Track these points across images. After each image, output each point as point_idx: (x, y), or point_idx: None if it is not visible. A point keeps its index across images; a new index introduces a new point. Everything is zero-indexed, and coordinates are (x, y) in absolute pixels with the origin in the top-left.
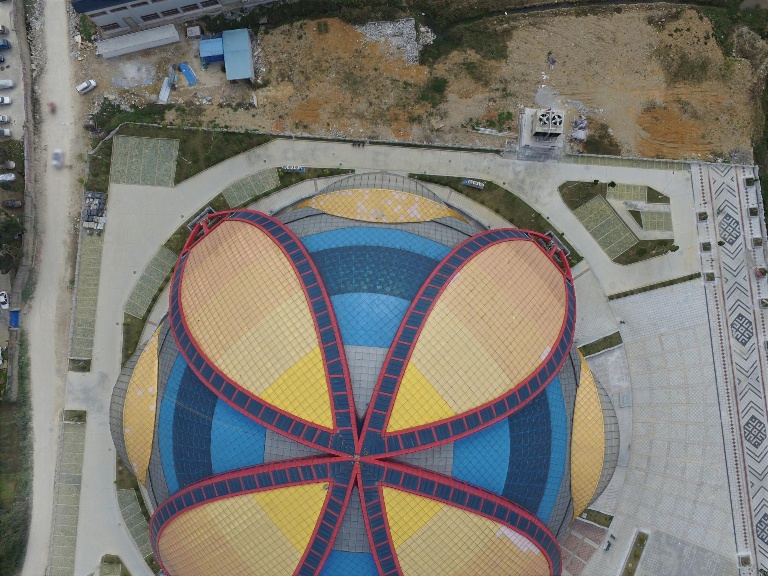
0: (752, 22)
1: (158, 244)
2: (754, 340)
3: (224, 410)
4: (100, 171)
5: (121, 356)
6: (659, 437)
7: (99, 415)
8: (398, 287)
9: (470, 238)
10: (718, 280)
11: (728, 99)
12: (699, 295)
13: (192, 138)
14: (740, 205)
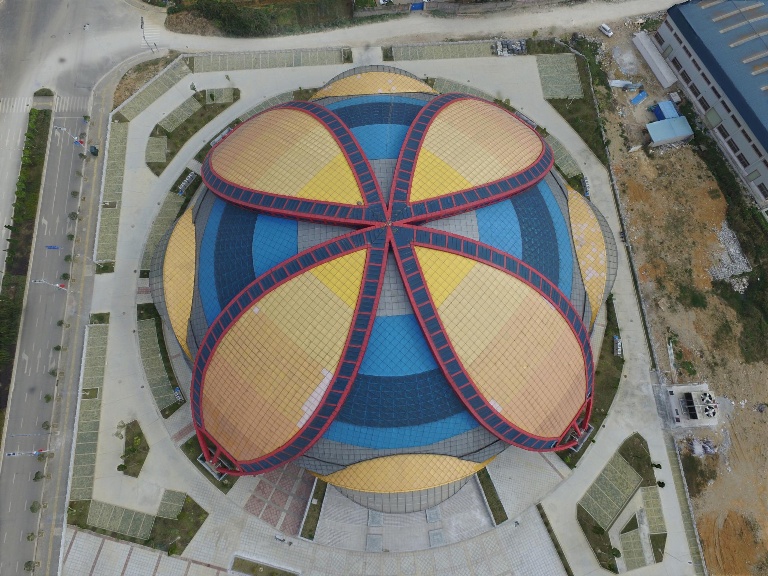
0: None
1: (495, 94)
2: None
3: (399, 130)
4: (543, 48)
5: None
6: None
7: None
8: (530, 255)
9: None
10: None
11: None
12: None
13: (588, 107)
14: None
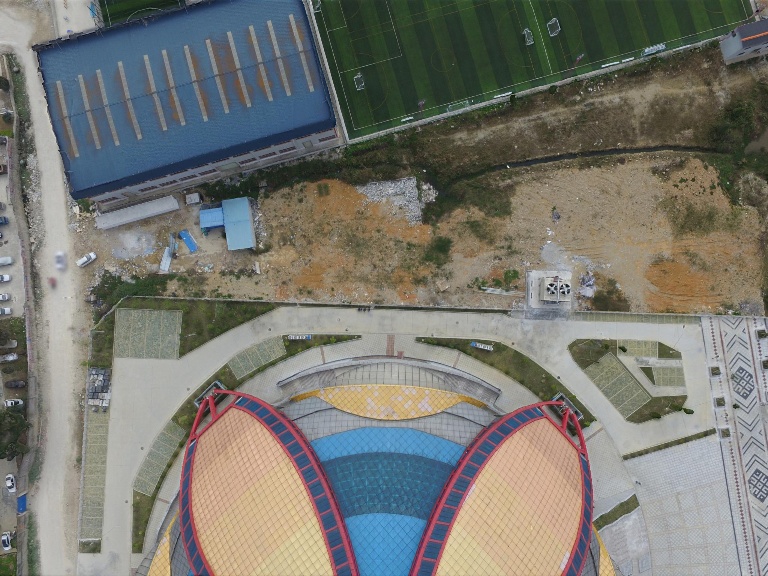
0: (757, 167)
1: (165, 418)
2: None
3: None
4: (103, 346)
5: (131, 535)
6: None
7: None
8: (413, 504)
9: (483, 436)
10: (733, 435)
11: (736, 249)
12: (715, 451)
13: (195, 308)
14: (753, 357)
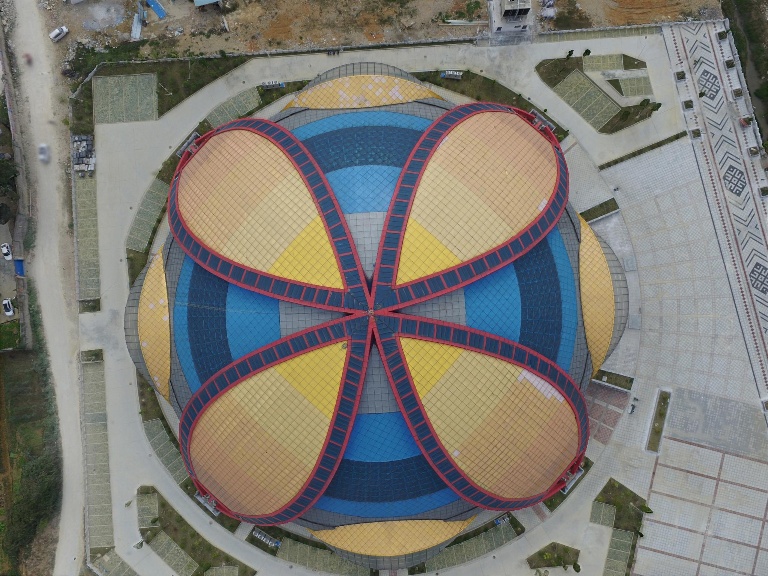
0: None
1: (150, 177)
2: (748, 189)
3: (235, 298)
4: (83, 114)
5: (129, 291)
6: (668, 297)
7: (115, 352)
8: (389, 157)
9: (454, 108)
10: (704, 136)
11: None
12: (688, 153)
13: (169, 69)
14: (716, 60)
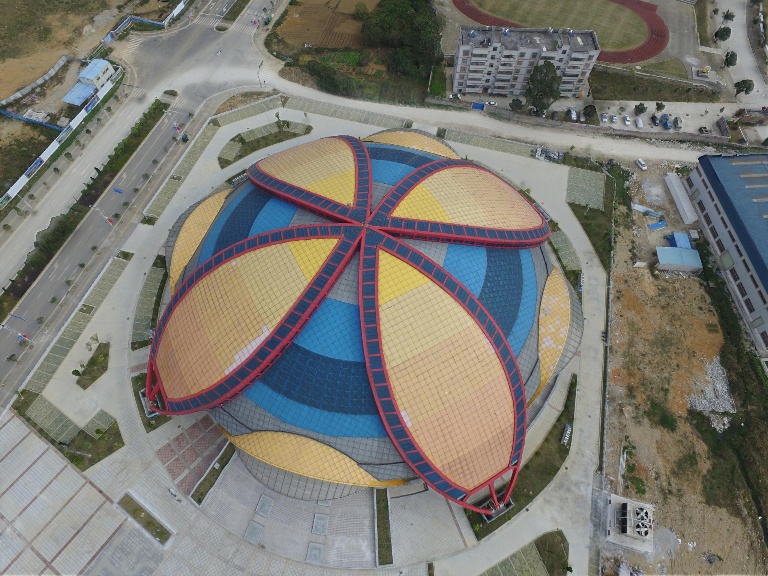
0: None
1: (522, 186)
2: None
3: (412, 170)
4: None
5: None
6: None
7: None
8: (487, 299)
9: None
10: None
11: None
12: None
13: (605, 219)
14: None
